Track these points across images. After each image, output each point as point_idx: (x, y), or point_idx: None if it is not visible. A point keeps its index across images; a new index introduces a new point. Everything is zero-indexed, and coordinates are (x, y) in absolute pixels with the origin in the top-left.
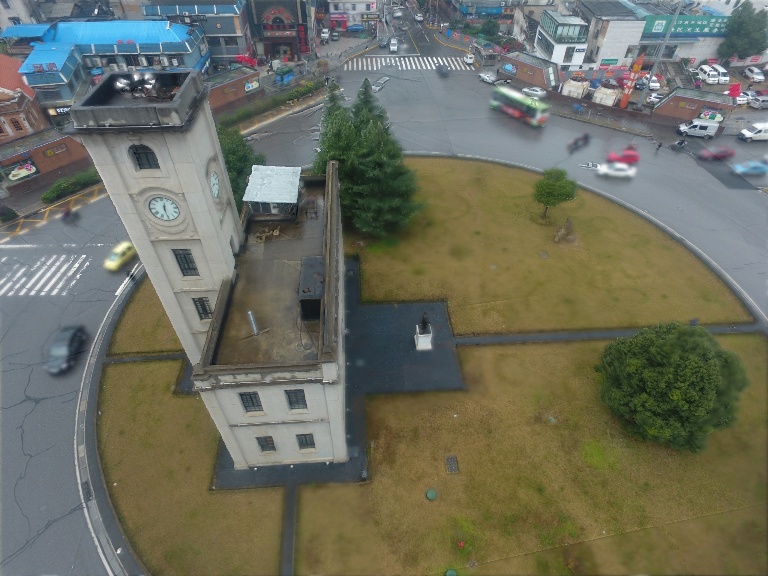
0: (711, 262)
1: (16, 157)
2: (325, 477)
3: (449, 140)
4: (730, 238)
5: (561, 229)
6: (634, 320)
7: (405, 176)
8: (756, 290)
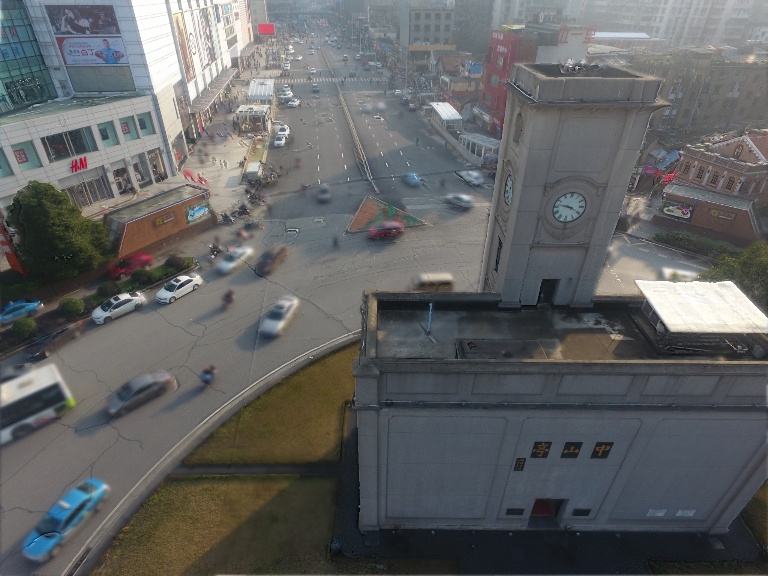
0: None
1: (685, 198)
2: (344, 504)
3: None
4: None
5: None
6: None
7: None
8: None
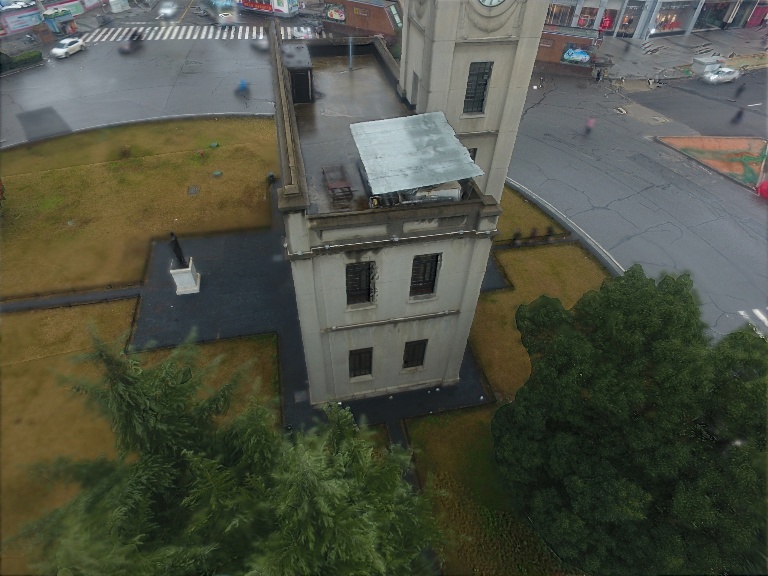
0: None
1: None
2: None
3: None
4: None
5: None
6: None
7: None
8: None
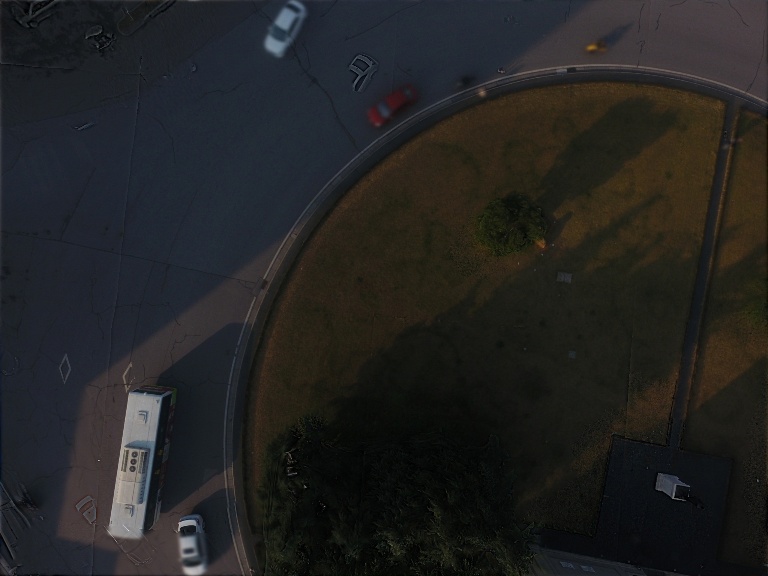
0: (624, 70)
1: None
2: None
3: (210, 275)
4: (587, 5)
5: (543, 238)
6: (692, 235)
7: (490, 484)
8: (681, 58)
